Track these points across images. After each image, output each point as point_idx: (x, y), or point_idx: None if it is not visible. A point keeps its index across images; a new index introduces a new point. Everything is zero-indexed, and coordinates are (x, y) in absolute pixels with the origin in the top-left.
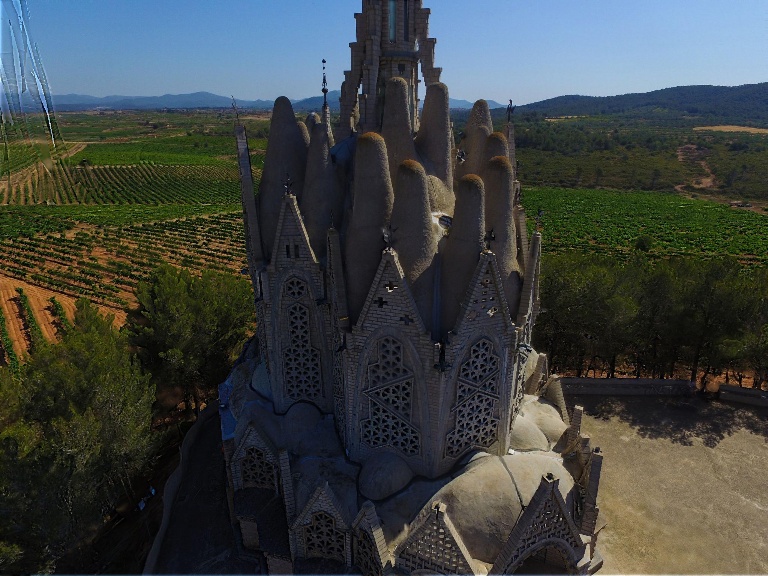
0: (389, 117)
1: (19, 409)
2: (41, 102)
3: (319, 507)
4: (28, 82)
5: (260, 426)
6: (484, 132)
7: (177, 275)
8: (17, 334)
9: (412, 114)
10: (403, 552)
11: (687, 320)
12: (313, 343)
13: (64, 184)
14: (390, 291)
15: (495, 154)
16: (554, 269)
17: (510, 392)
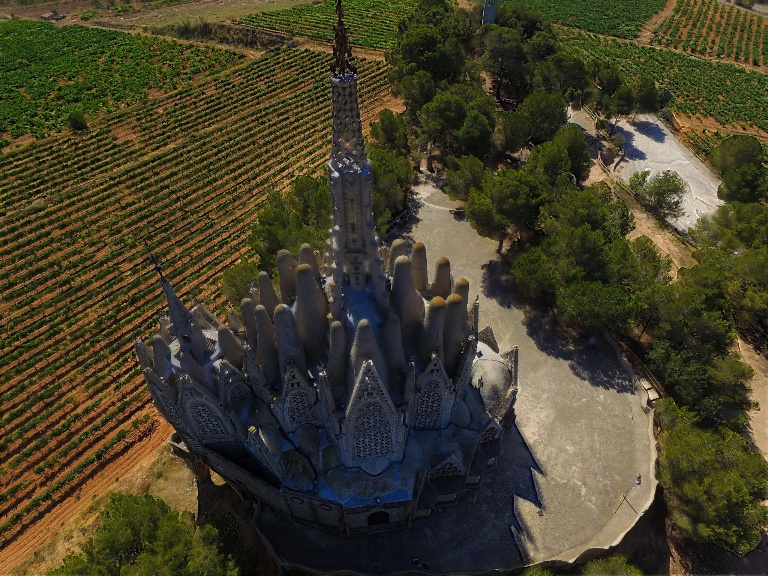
0: (407, 280)
1: None
2: None
3: None
4: None
5: (417, 471)
6: None
7: None
8: None
9: None
10: None
11: None
12: None
13: None
14: None
15: None
16: None
17: None
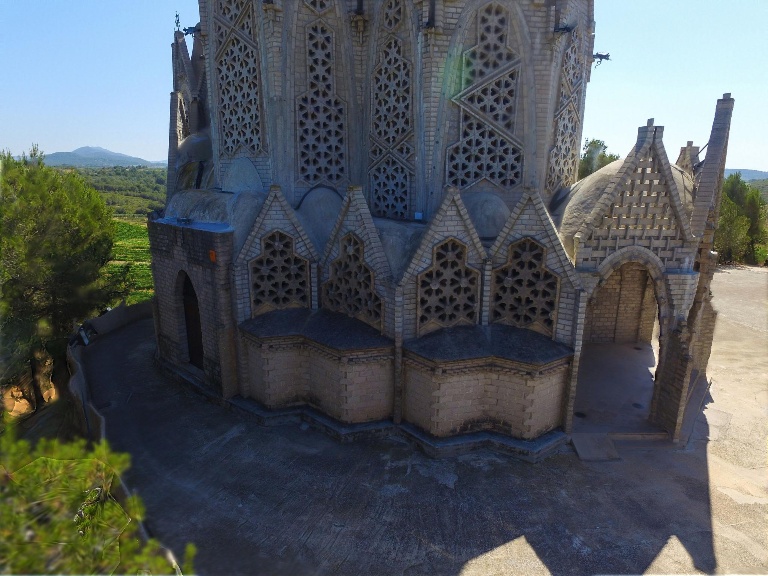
0: None
1: None
2: None
3: (445, 231)
4: None
5: None
6: None
7: None
8: None
9: None
10: (589, 236)
11: None
12: (338, 90)
13: None
14: None
15: None
16: None
17: None
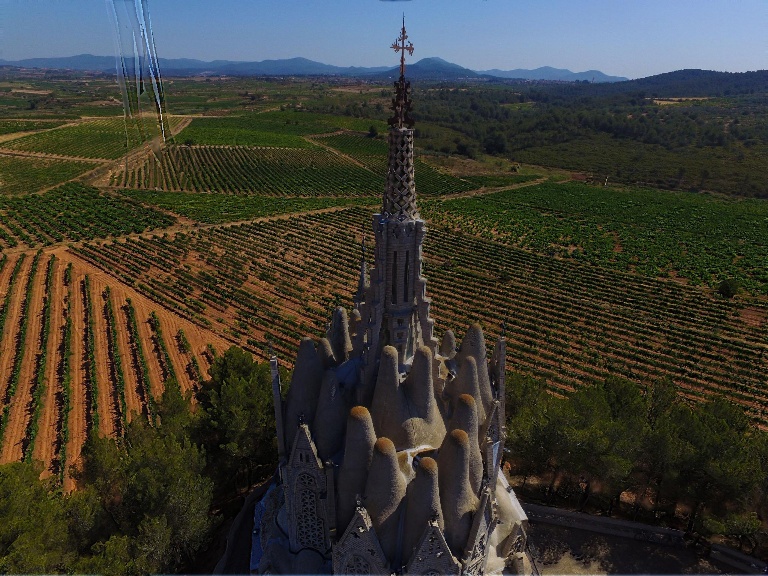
0: (382, 375)
1: (120, 475)
2: (155, 96)
3: None
4: (145, 82)
5: (276, 566)
6: (470, 364)
7: (242, 359)
8: (125, 348)
9: (411, 343)
10: None
11: (678, 489)
12: (319, 514)
13: (170, 173)
14: (362, 531)
15: (463, 415)
16: (556, 419)
17: None
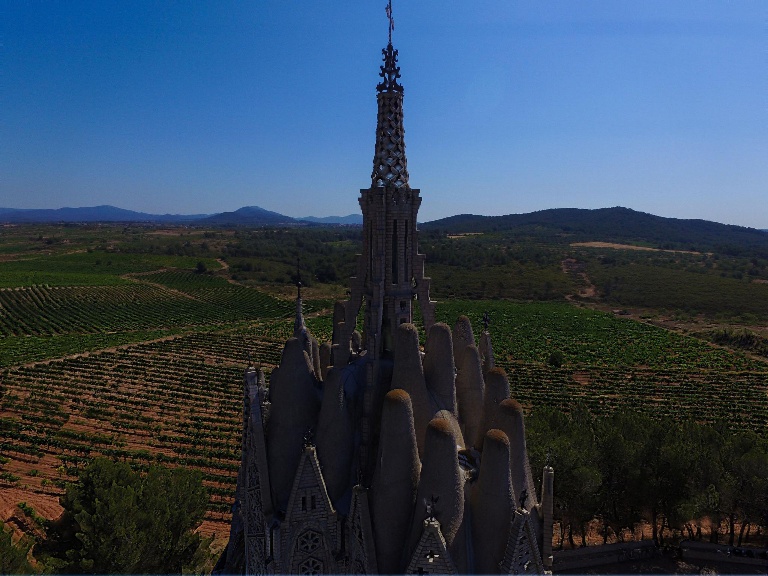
0: (402, 360)
1: None
2: None
3: None
4: None
5: None
6: (474, 352)
7: (115, 472)
8: None
9: None
10: None
11: (645, 484)
12: None
13: None
14: (431, 560)
15: (500, 389)
16: None
17: None
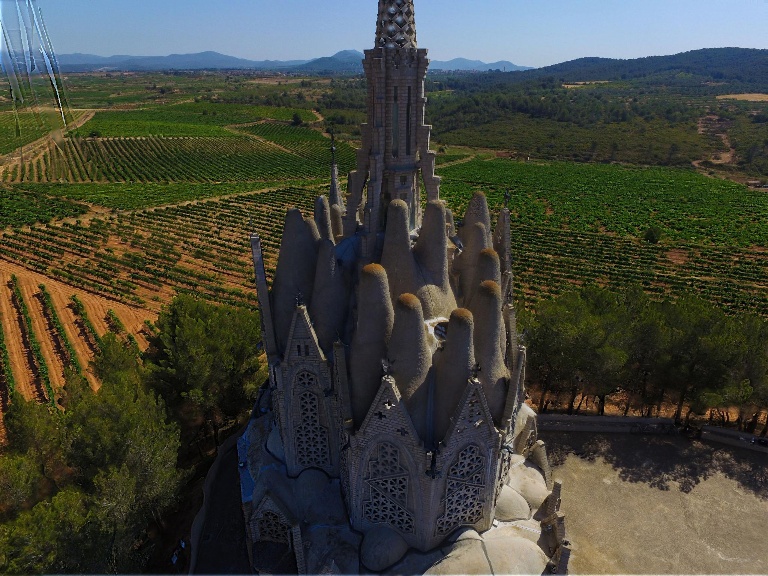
0: (391, 236)
1: (58, 443)
2: (50, 77)
3: None
4: (36, 59)
5: (275, 492)
6: (480, 230)
7: (194, 306)
8: (43, 334)
9: (413, 213)
10: None
11: (673, 370)
12: (321, 422)
13: (76, 162)
14: (388, 408)
15: (487, 270)
16: (549, 318)
17: (494, 480)
